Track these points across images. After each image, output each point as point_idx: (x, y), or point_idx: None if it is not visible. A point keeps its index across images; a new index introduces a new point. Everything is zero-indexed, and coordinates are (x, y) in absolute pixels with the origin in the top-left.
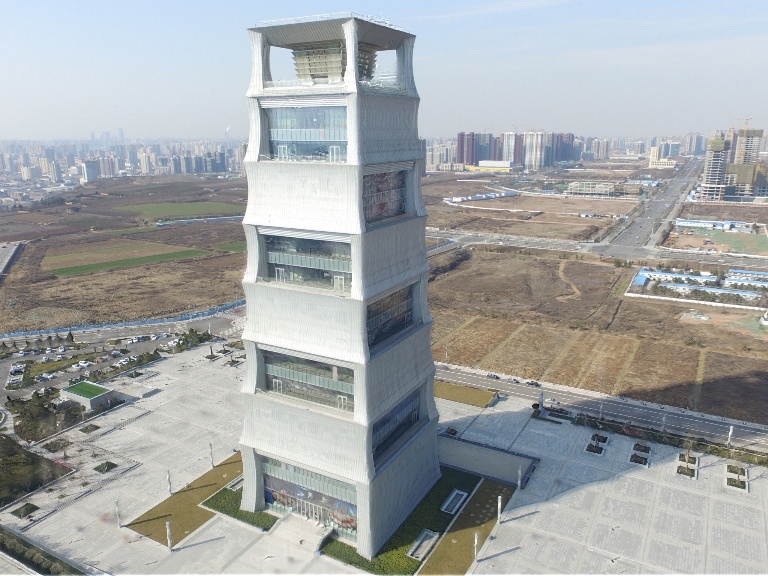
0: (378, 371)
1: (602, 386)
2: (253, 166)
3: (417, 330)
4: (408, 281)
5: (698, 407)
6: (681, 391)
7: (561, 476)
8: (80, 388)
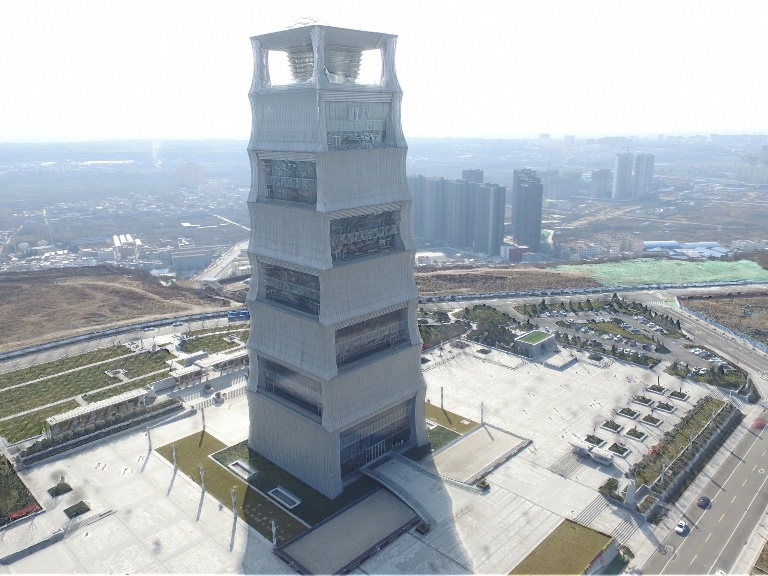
0: (261, 317)
1: None
2: None
3: (303, 318)
4: (297, 266)
5: None
6: None
7: None
8: (540, 335)
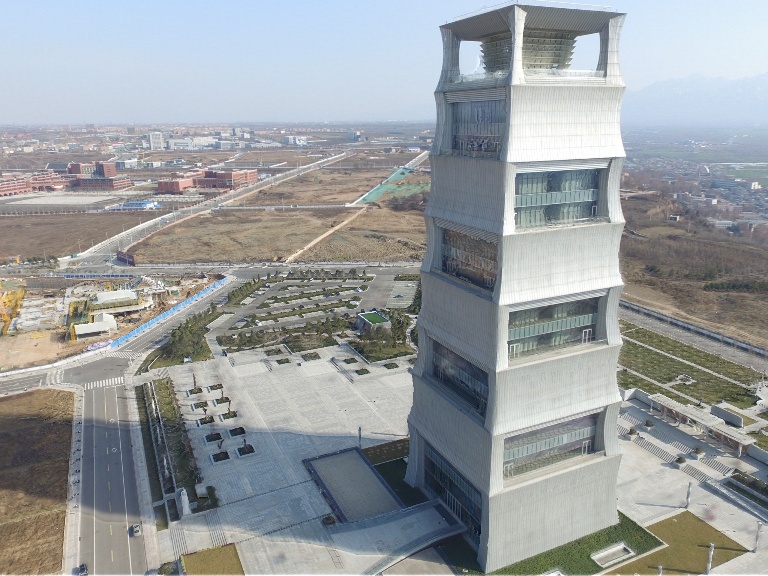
0: None
1: (36, 525)
2: (616, 160)
3: None
4: None
5: (56, 458)
6: (8, 478)
7: (314, 445)
8: None
